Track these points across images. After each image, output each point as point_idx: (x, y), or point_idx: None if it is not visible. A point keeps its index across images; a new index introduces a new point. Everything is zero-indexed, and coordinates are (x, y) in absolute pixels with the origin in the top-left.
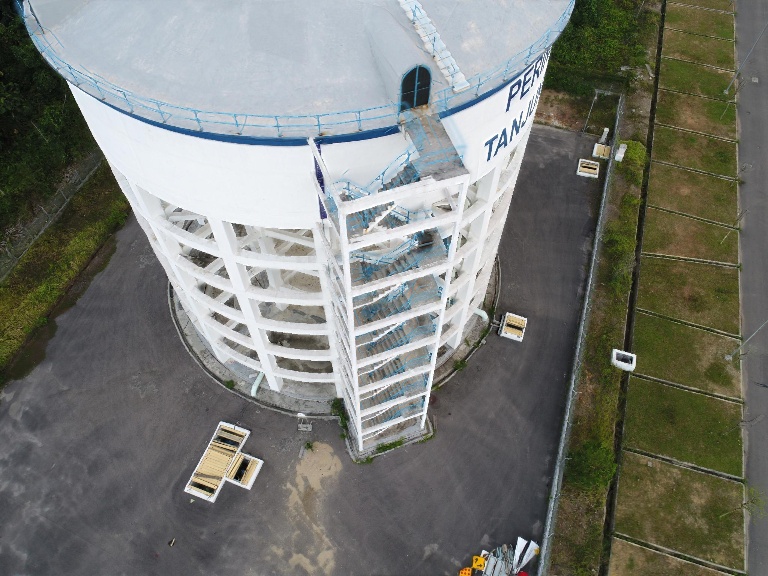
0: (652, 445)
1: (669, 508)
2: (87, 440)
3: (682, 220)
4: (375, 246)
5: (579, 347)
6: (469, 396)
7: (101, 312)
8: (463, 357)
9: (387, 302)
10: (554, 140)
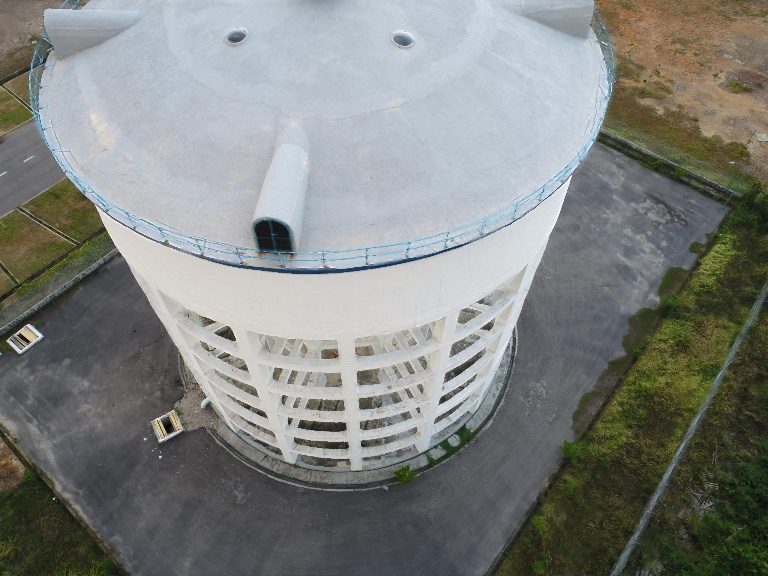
0: None
1: None
2: (583, 246)
3: (7, 259)
4: None
5: None
6: None
7: (582, 346)
8: None
9: None
10: (16, 394)
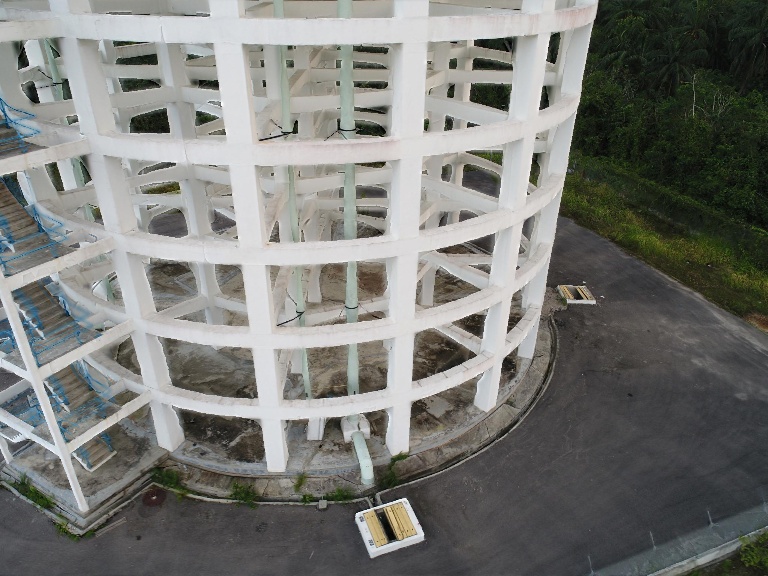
0: None
1: None
2: None
3: None
4: (365, 316)
5: None
6: (193, 545)
7: None
8: (270, 496)
9: (289, 365)
10: None
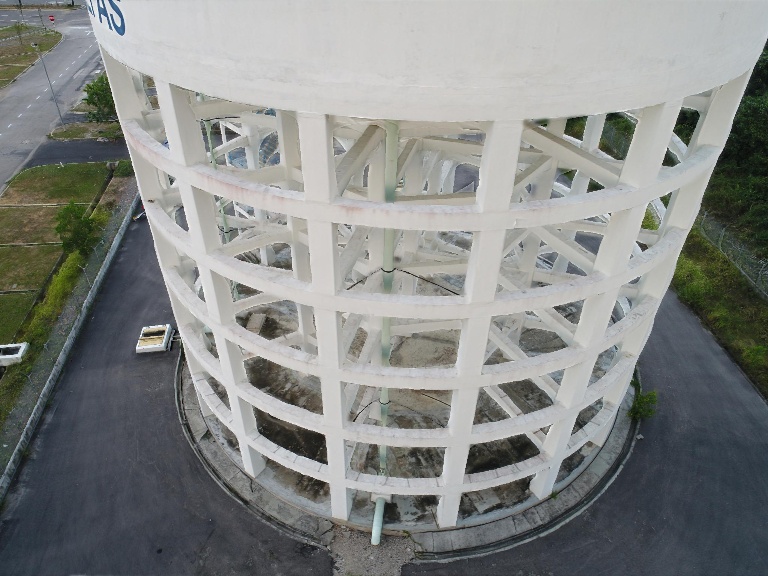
0: (6, 298)
1: (8, 265)
2: None
3: None
4: None
5: (69, 336)
6: None
7: (587, 237)
8: None
9: None
10: None
